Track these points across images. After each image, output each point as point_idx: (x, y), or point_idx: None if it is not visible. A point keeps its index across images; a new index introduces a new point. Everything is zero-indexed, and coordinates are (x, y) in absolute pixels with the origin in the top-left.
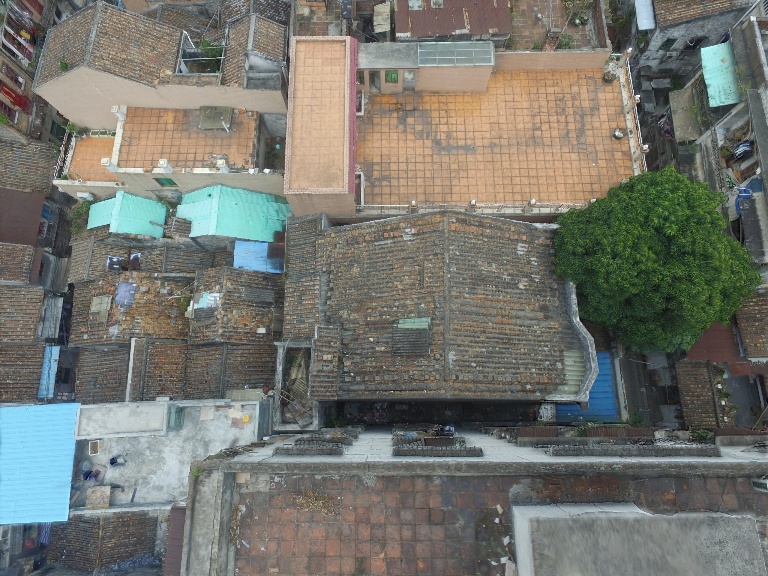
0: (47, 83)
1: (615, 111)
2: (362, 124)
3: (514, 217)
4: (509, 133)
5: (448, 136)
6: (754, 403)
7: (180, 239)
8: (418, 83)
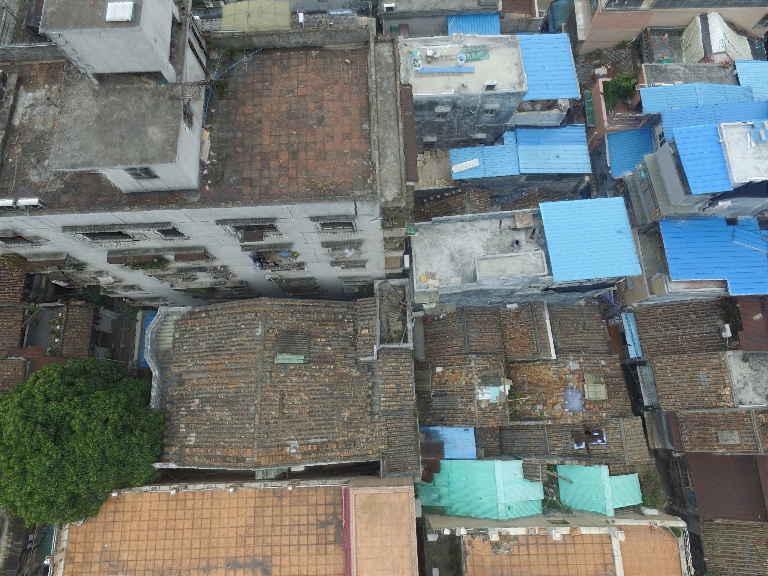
0: None
1: None
2: None
3: None
4: None
5: None
6: (34, 329)
7: None
8: None
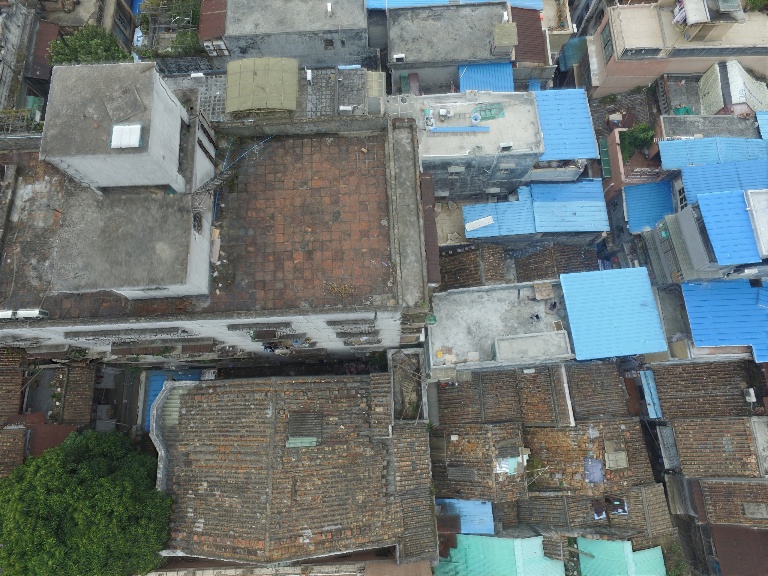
0: None
1: None
2: None
3: (205, 567)
4: None
5: None
6: (34, 391)
7: (553, 535)
8: None
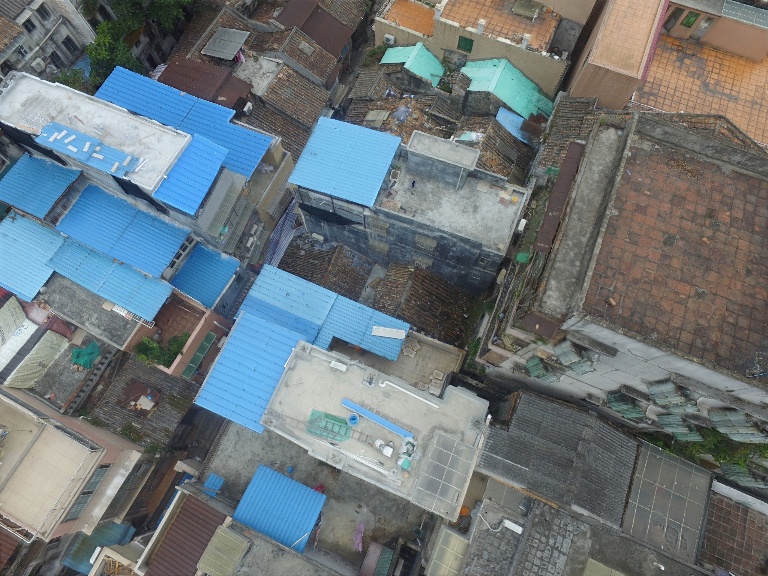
0: None
1: None
2: None
3: None
4: None
5: (716, 83)
6: None
7: (456, 91)
8: (708, 33)
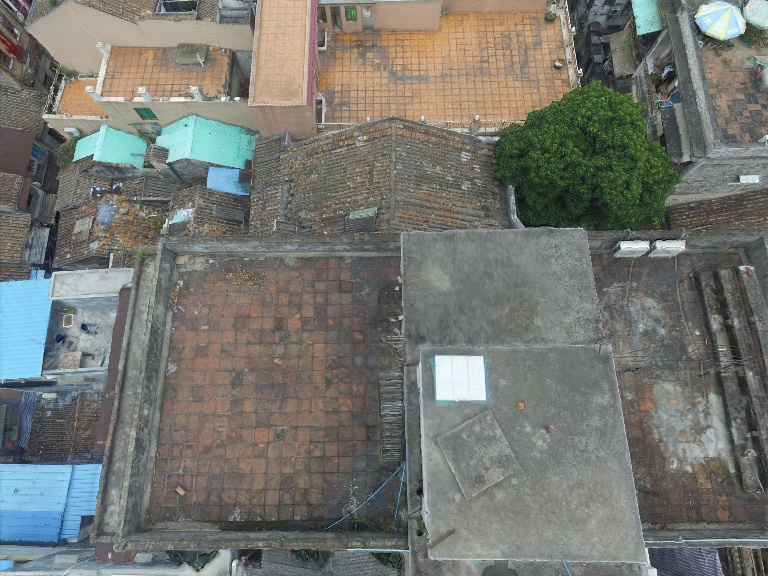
0: (38, 20)
1: (556, 45)
2: (325, 58)
3: None
4: (459, 65)
5: (403, 68)
6: None
7: (158, 166)
8: (376, 20)
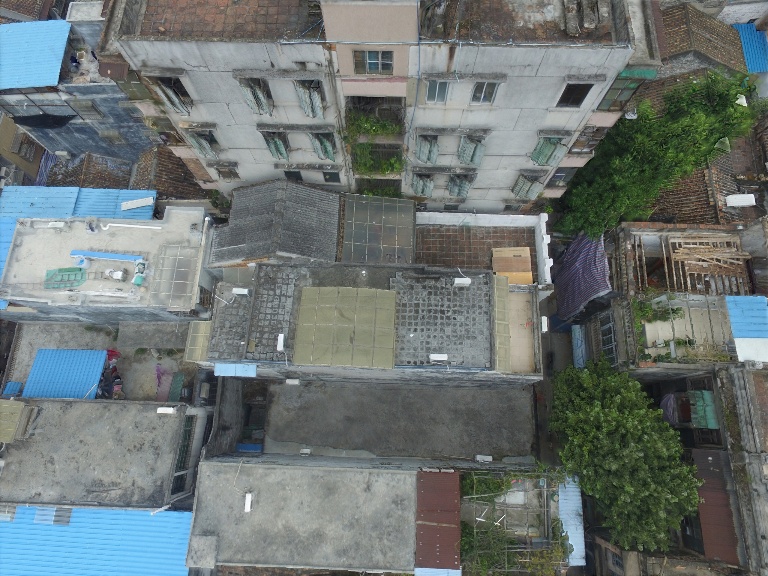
0: None
1: None
2: None
3: None
4: None
5: None
6: None
7: None
8: None
